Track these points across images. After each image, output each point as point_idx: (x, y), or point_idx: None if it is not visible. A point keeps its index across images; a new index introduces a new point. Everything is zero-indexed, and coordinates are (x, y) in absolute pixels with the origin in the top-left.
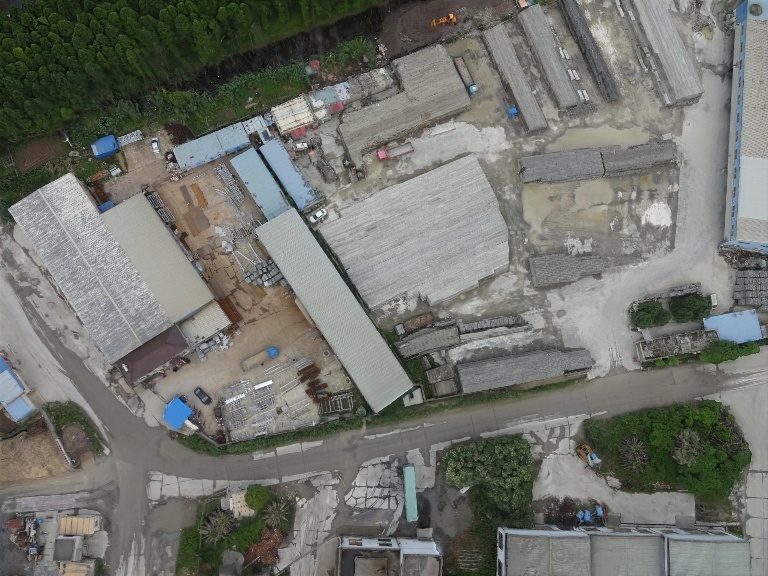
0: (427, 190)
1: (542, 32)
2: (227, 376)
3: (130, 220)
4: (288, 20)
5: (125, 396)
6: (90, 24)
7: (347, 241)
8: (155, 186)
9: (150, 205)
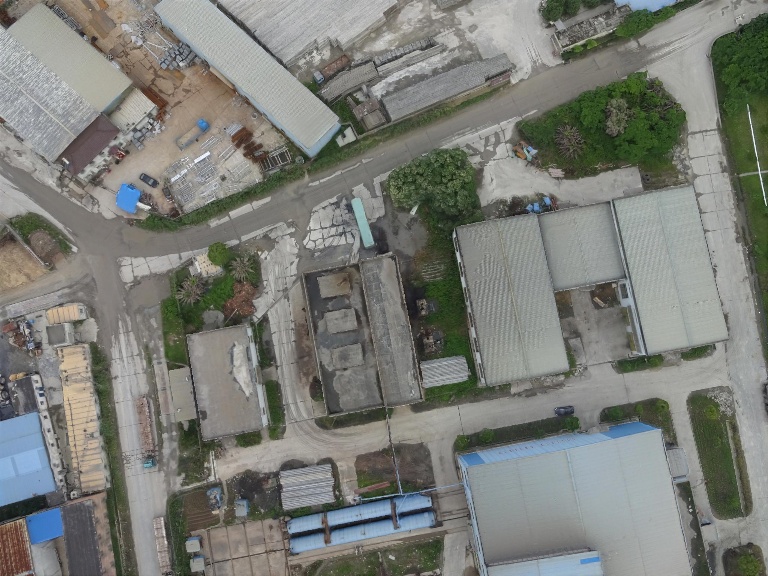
0: None
1: None
2: (167, 158)
3: (36, 29)
4: None
5: (78, 197)
6: None
7: (248, 6)
8: (55, 1)
9: (51, 11)
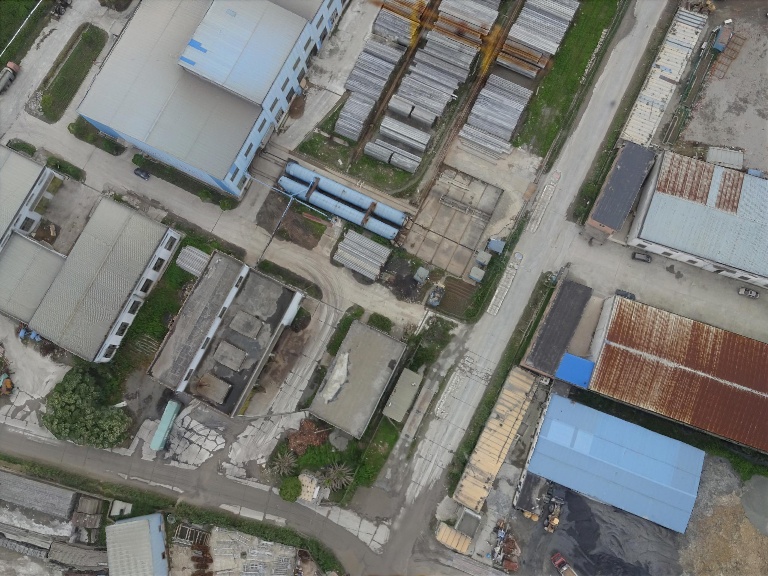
0: None
1: None
2: None
3: None
4: None
5: None
6: None
7: None
8: None
9: None
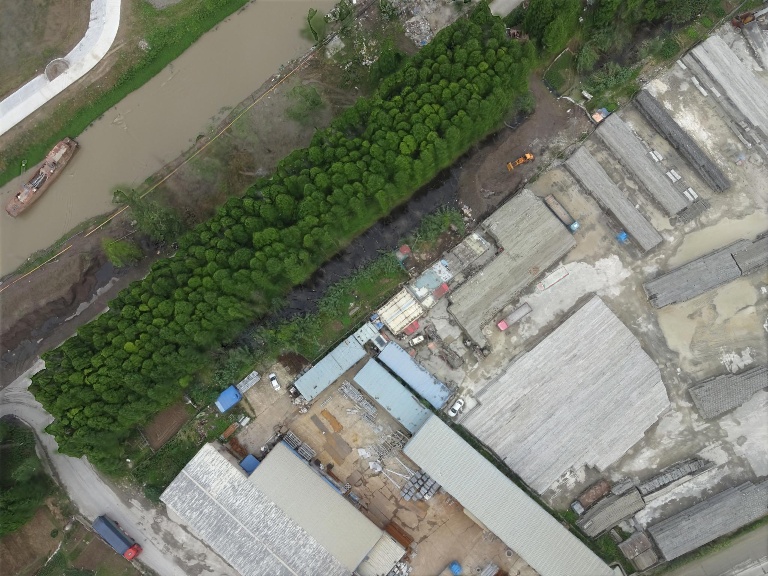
0: (560, 350)
1: (627, 142)
2: None
3: (278, 475)
4: (366, 213)
5: None
6: (189, 298)
7: (495, 429)
8: (286, 424)
9: (292, 453)
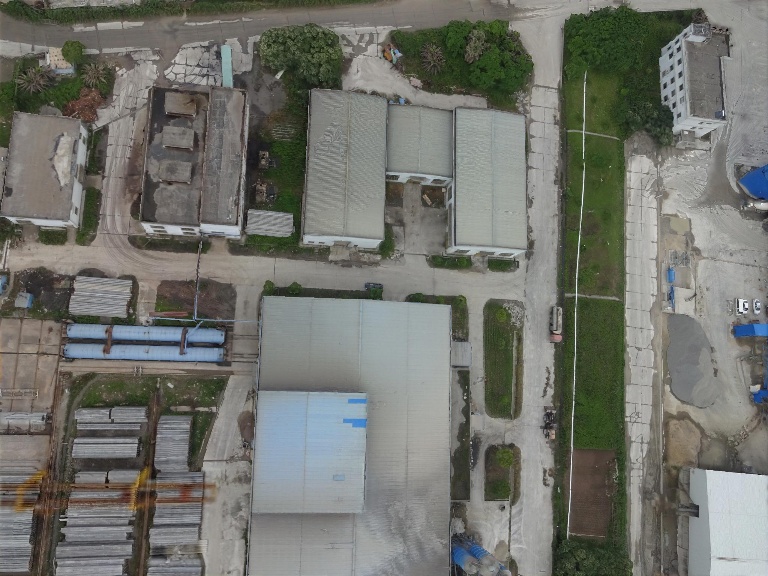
0: None
1: None
2: None
3: None
4: None
5: None
6: None
7: None
8: None
9: None
